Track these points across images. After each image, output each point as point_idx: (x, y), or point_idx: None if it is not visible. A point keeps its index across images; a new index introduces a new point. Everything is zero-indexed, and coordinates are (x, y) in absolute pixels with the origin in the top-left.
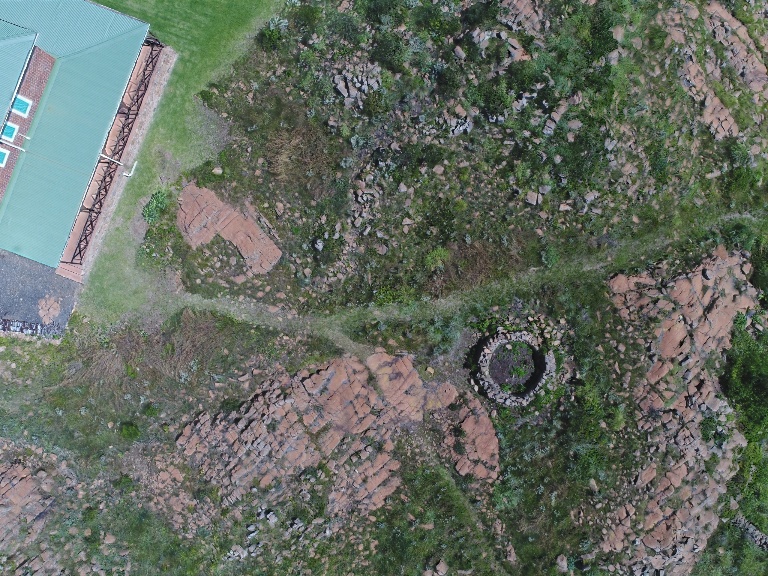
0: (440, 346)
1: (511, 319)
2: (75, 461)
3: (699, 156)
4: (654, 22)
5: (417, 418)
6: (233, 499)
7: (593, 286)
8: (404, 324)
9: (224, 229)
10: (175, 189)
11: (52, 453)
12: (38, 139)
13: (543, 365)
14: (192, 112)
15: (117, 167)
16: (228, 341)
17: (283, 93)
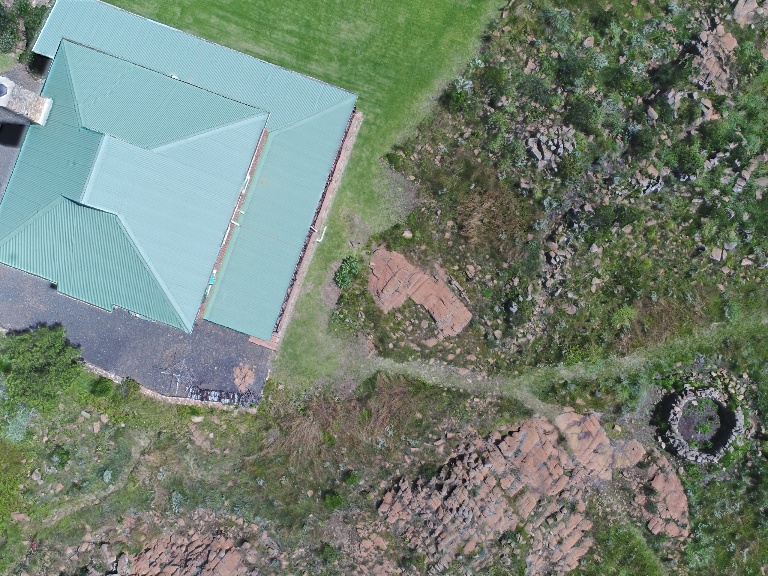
0: (628, 404)
1: (695, 375)
2: (275, 531)
3: None
4: None
5: (606, 477)
6: (441, 567)
7: None
8: (592, 383)
9: (415, 293)
10: (366, 254)
11: (253, 523)
12: (252, 213)
13: (731, 421)
14: (379, 175)
15: (312, 234)
16: (421, 405)
17: (472, 155)
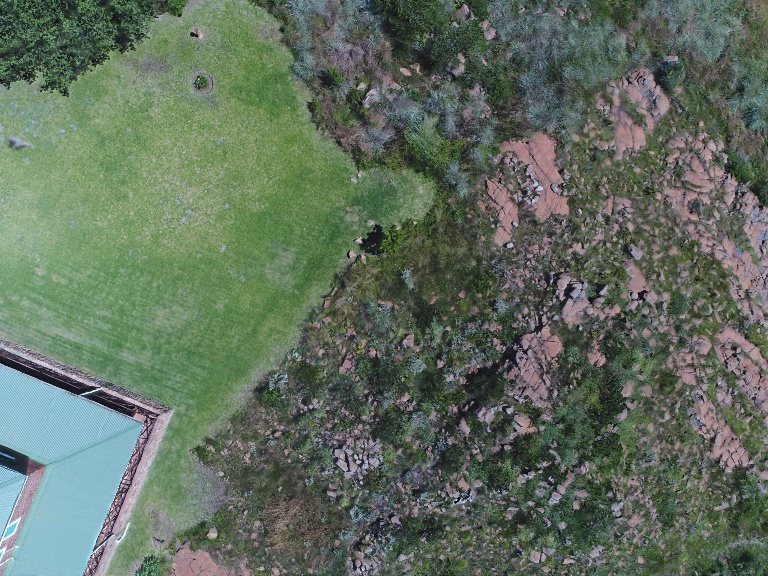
0: None
1: None
2: None
3: (707, 489)
4: (665, 366)
5: None
6: None
7: None
8: None
9: None
10: (168, 553)
11: None
12: (27, 546)
13: None
14: (187, 469)
15: None
16: None
17: (281, 456)
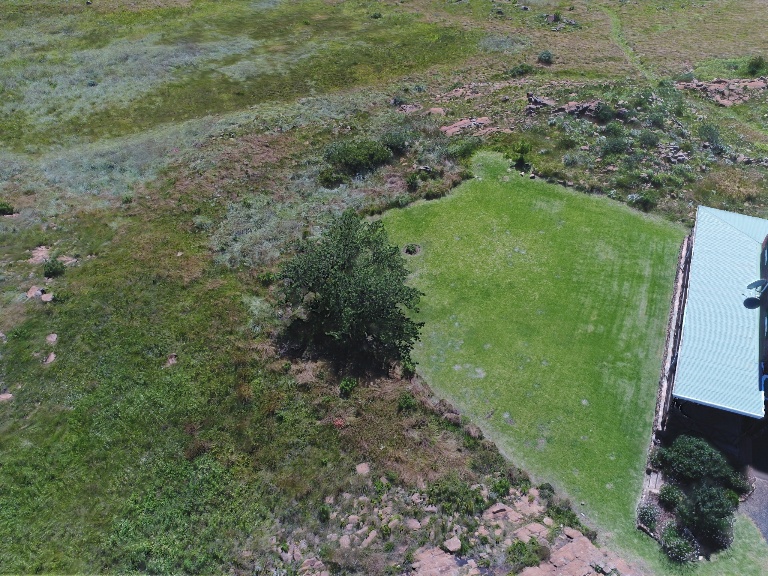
0: None
1: None
2: None
3: None
4: None
5: None
6: None
7: (735, 108)
8: None
9: None
10: None
11: None
12: None
13: None
14: None
15: None
16: None
17: None
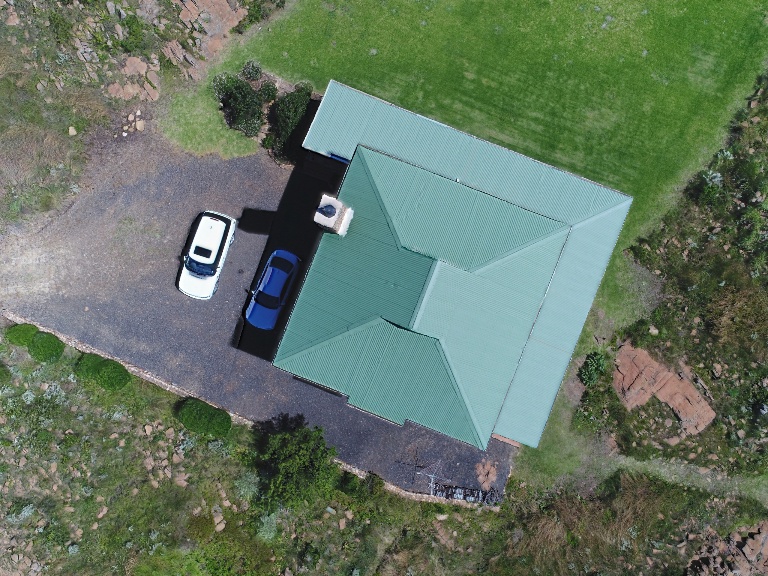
0: None
1: None
2: None
3: None
4: None
5: None
6: None
7: None
8: None
9: (660, 391)
10: (611, 350)
11: None
12: None
13: None
14: (623, 268)
15: None
16: (662, 505)
17: (722, 251)
